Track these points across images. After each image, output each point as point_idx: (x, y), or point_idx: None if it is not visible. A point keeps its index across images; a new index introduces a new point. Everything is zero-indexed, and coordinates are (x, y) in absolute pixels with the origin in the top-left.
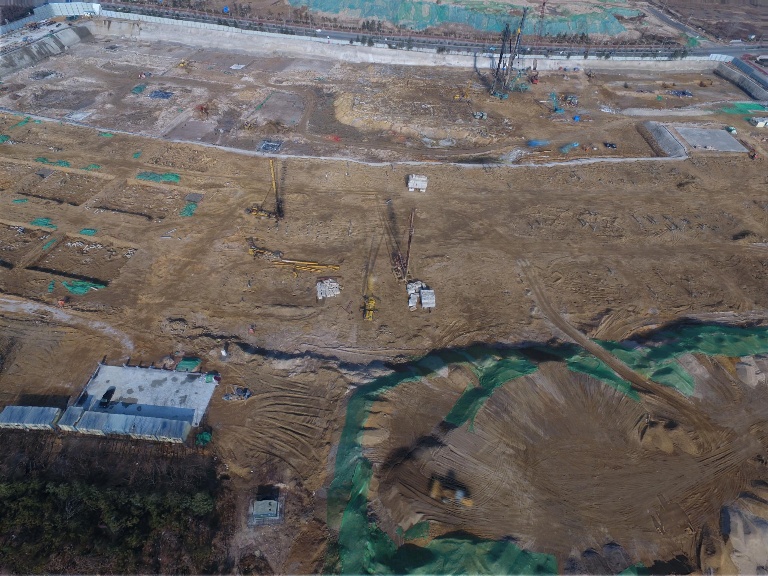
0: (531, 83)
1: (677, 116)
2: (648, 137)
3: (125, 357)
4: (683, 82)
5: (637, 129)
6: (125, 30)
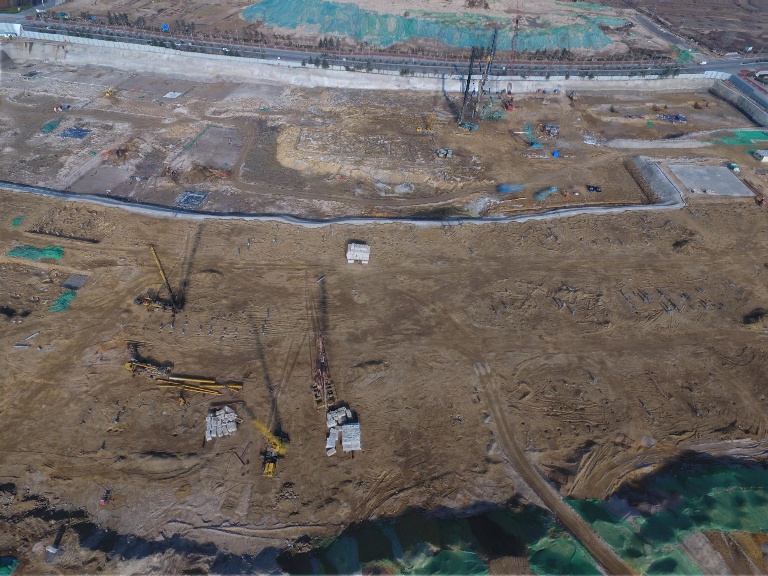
0: (505, 109)
1: (670, 148)
2: (638, 176)
3: None
4: (676, 104)
5: (625, 166)
6: (49, 53)
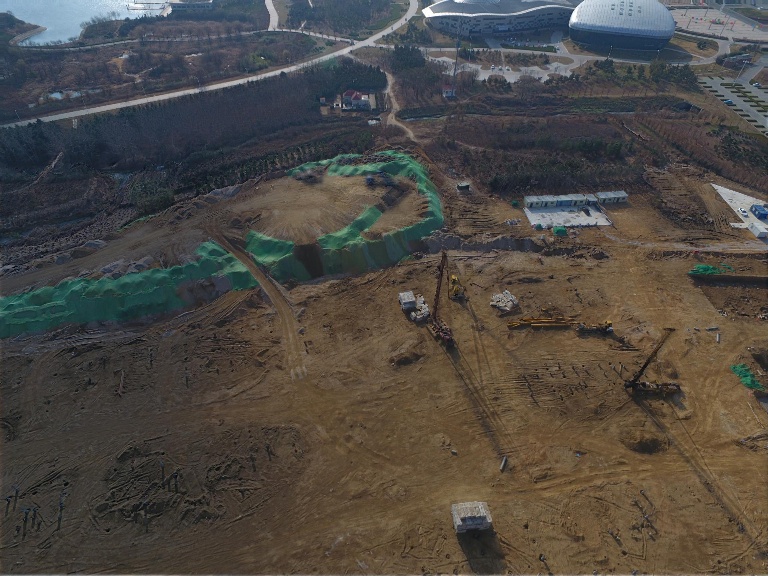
0: None
1: None
2: None
3: (604, 230)
4: None
5: None
6: None
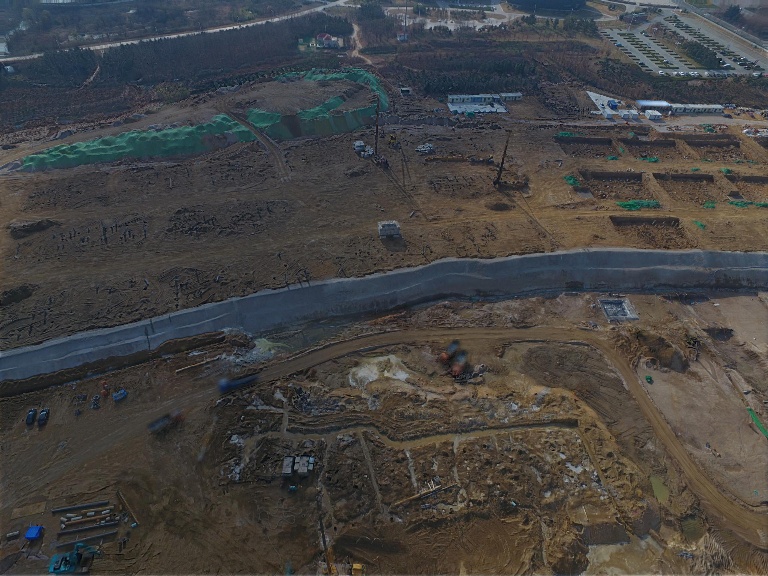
0: None
1: None
2: None
3: None
4: None
5: None
6: None
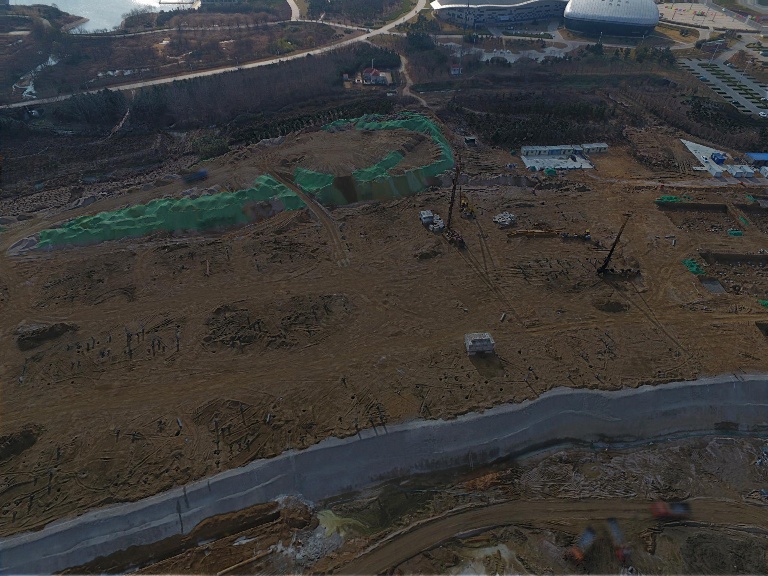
0: None
1: None
2: None
3: (587, 172)
4: None
5: None
6: None
